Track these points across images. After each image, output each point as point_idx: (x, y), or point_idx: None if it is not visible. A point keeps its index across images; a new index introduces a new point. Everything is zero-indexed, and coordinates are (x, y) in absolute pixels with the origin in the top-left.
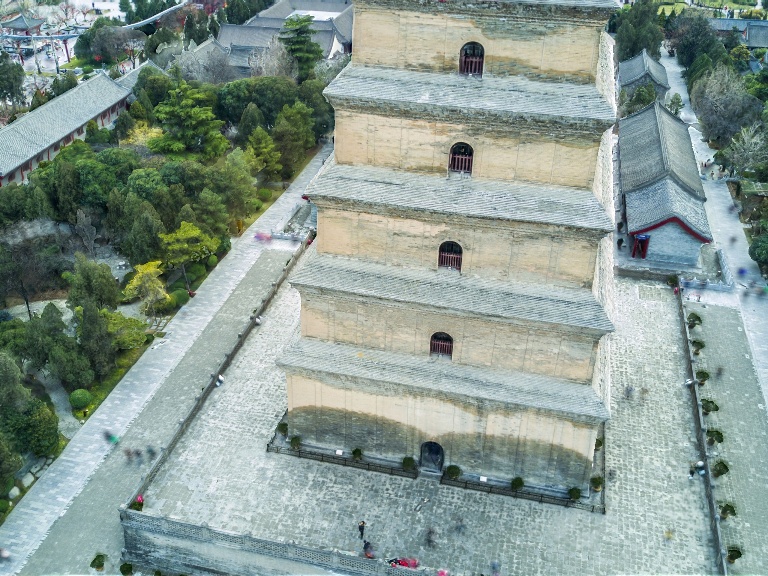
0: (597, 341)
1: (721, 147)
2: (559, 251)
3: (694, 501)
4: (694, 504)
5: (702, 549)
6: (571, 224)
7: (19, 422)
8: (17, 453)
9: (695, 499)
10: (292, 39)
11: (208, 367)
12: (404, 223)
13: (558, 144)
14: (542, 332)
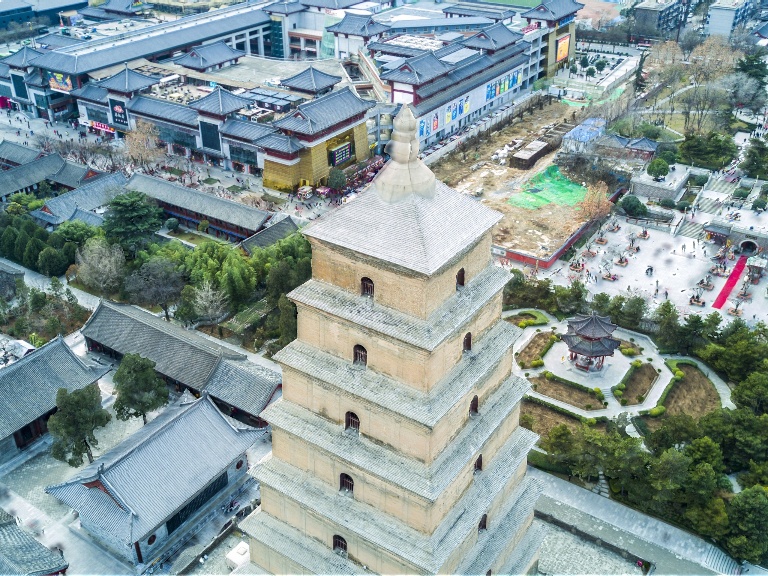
0: None
1: (161, 306)
2: None
3: (551, 531)
4: (554, 532)
5: (587, 546)
6: None
7: None
8: None
9: (550, 529)
10: None
11: None
12: None
13: None
14: None
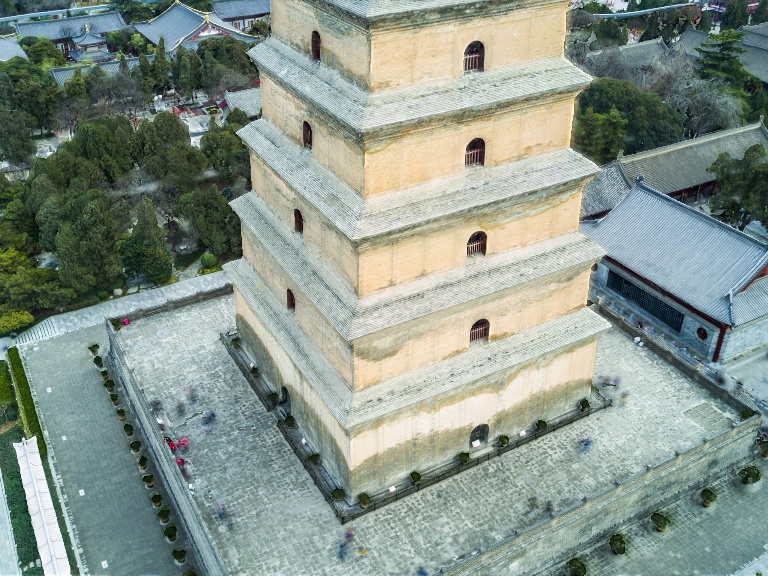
0: (352, 349)
1: None
2: None
3: (425, 574)
4: (421, 575)
5: None
6: (333, 221)
7: (139, 248)
8: (133, 269)
9: (429, 573)
10: (710, 53)
11: None
12: None
13: (345, 143)
14: None
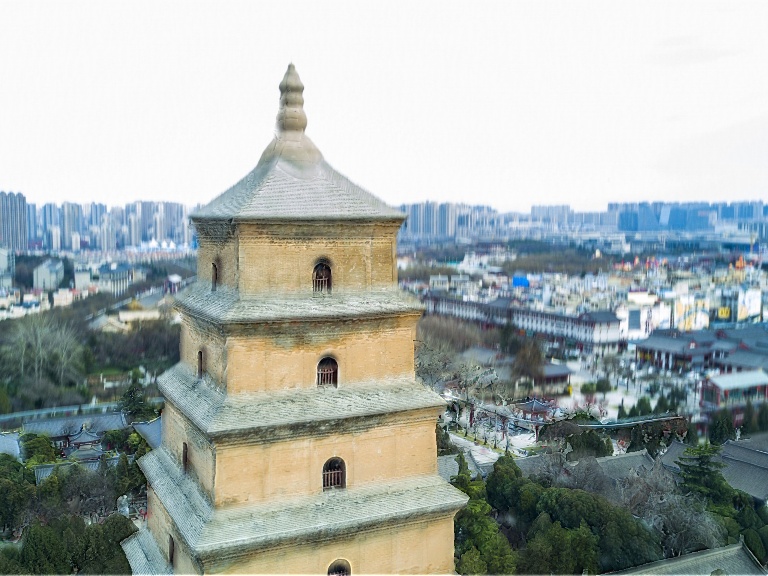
0: None
1: None
2: None
3: None
4: None
5: None
6: None
7: None
8: None
9: None
10: (690, 467)
11: None
12: None
13: (191, 561)
14: None
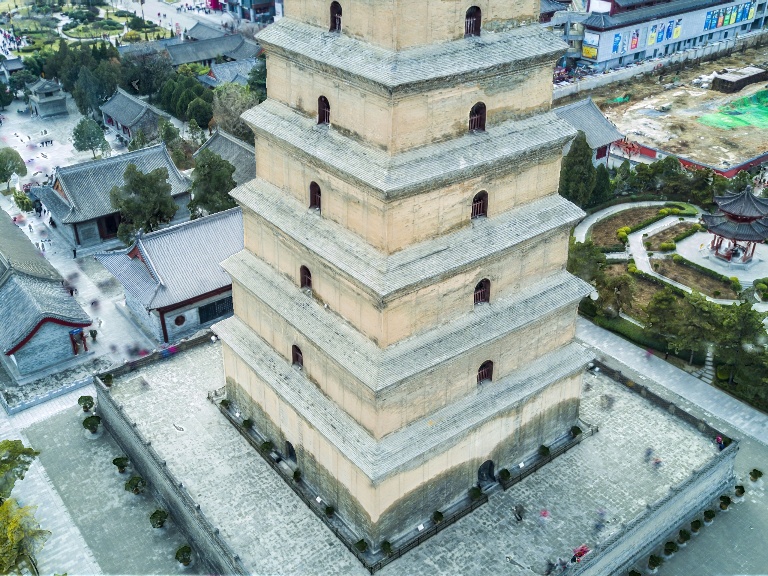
0: None
1: None
2: (549, 249)
3: (616, 389)
4: (618, 390)
5: (656, 412)
6: (564, 223)
7: None
8: None
9: (615, 387)
10: None
11: (154, 571)
12: (451, 282)
13: (540, 165)
14: (548, 319)
